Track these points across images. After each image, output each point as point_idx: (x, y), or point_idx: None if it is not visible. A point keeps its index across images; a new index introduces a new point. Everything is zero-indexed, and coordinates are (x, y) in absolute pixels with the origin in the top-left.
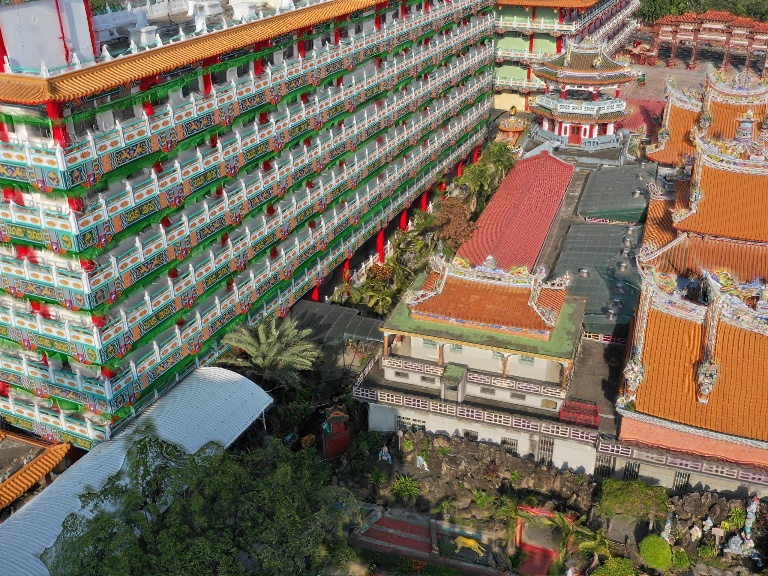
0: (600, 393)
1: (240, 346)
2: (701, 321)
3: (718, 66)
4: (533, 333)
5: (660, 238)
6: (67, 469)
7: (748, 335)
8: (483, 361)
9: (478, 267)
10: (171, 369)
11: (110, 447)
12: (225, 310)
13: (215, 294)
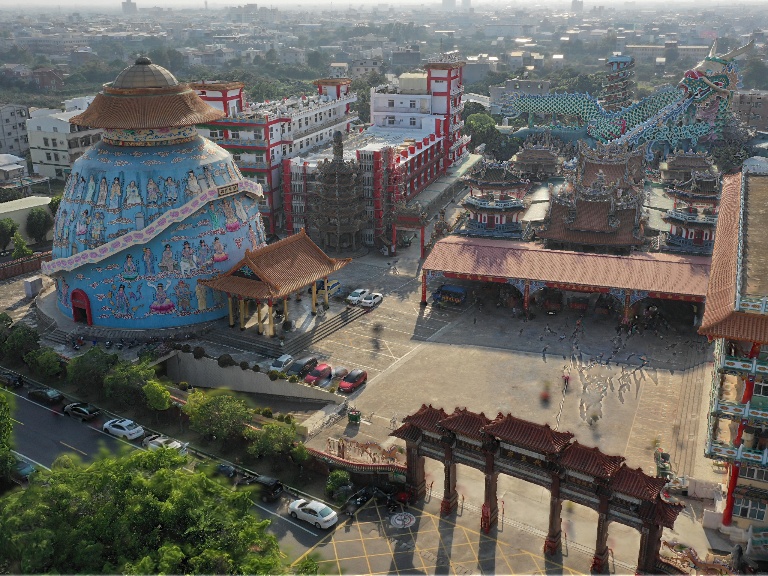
0: None
1: None
2: None
3: (486, 569)
4: None
5: None
6: None
7: None
8: None
9: None
10: None
11: None
12: None
13: None
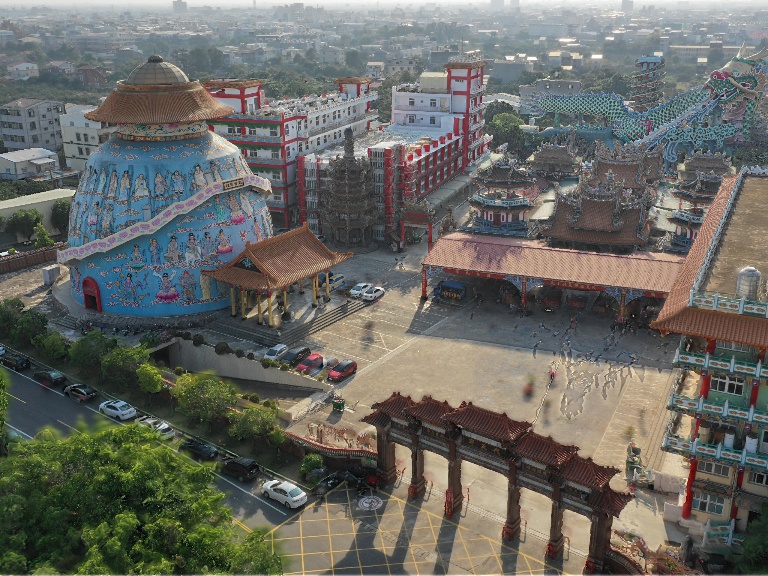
0: None
1: None
2: None
3: (443, 551)
4: None
5: None
6: None
7: None
8: None
9: None
10: None
11: None
12: None
13: None
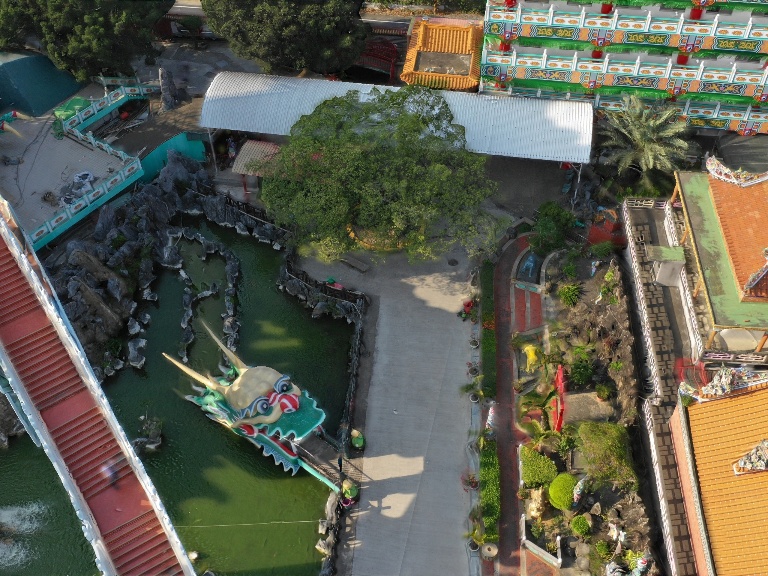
0: None
1: (632, 112)
2: None
3: None
4: None
5: None
6: None
7: None
8: None
9: None
10: (554, 82)
11: (467, 95)
12: (645, 75)
13: (653, 57)
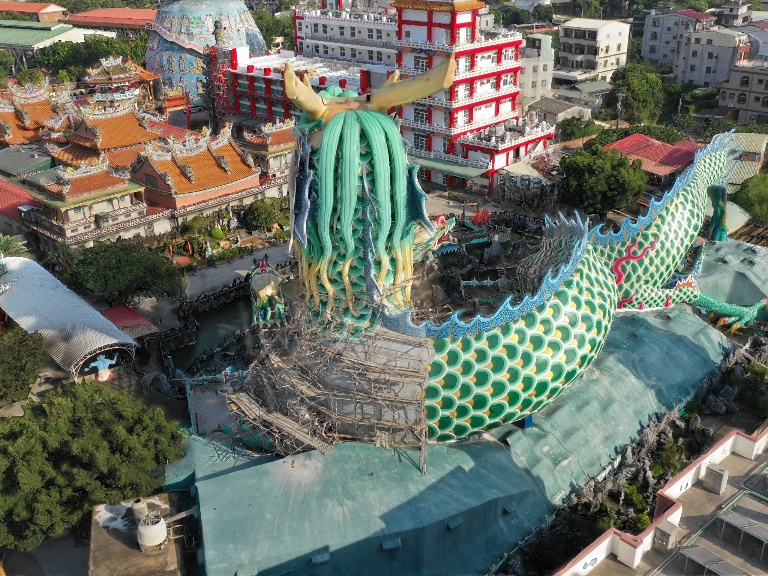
0: (148, 207)
1: None
2: (171, 159)
3: None
4: (121, 185)
5: (88, 161)
6: (6, 305)
7: (188, 158)
8: (104, 210)
9: (79, 169)
10: None
11: (15, 288)
12: None
13: None
